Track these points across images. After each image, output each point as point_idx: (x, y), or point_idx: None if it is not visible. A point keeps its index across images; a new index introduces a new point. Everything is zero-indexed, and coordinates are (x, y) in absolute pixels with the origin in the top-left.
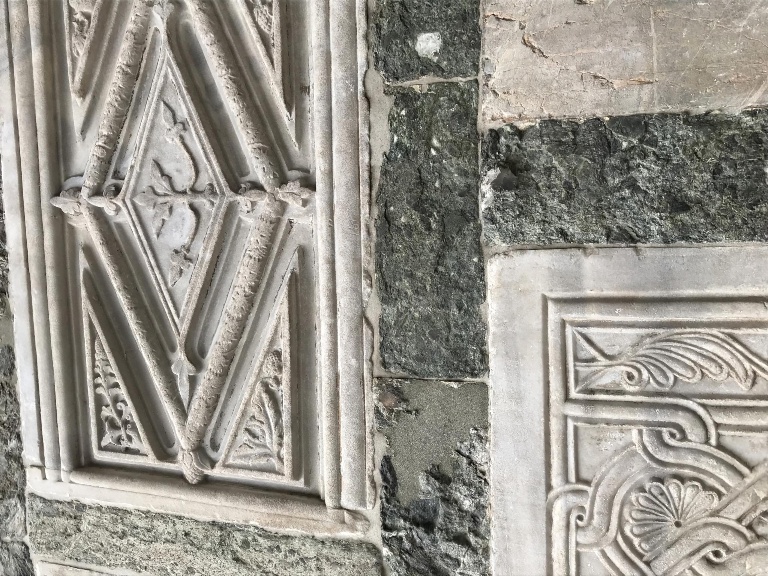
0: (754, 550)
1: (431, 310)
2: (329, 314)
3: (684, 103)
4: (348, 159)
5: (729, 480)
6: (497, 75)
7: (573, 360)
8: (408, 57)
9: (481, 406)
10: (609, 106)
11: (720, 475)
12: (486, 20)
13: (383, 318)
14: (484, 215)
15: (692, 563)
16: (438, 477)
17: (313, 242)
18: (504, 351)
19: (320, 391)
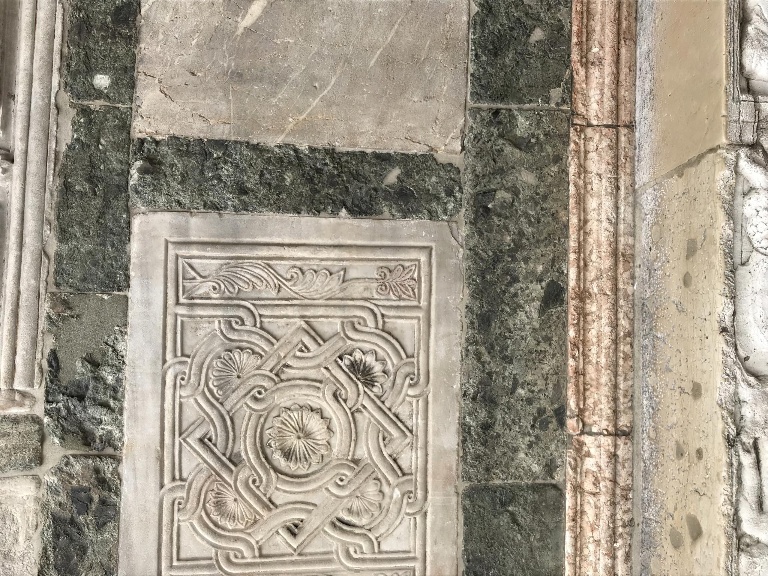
0: (279, 388)
1: (92, 247)
2: (16, 248)
3: (246, 137)
4: (40, 145)
5: (266, 347)
6: (143, 106)
7: (182, 279)
8: (87, 87)
9: (123, 311)
10: (207, 133)
11: (262, 345)
12: (138, 74)
13: (57, 252)
14: (131, 188)
15: (246, 400)
16: (90, 362)
17: (8, 200)
18: (140, 274)
19: (4, 306)
